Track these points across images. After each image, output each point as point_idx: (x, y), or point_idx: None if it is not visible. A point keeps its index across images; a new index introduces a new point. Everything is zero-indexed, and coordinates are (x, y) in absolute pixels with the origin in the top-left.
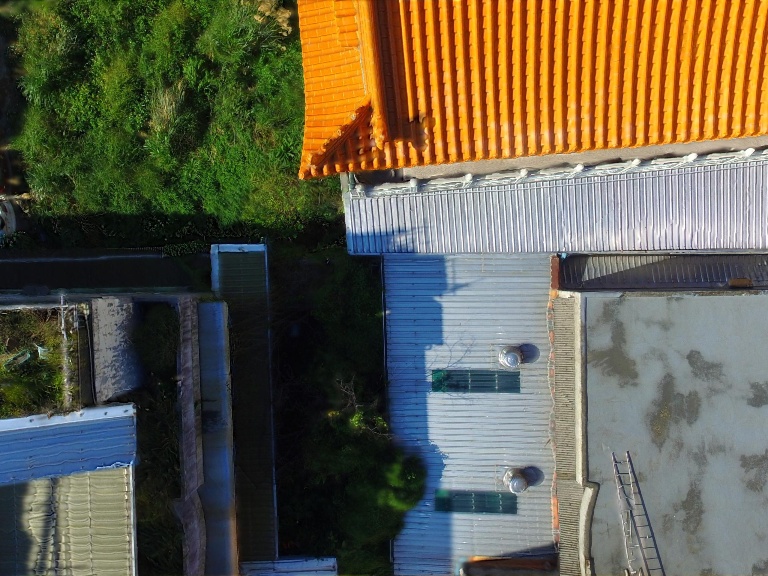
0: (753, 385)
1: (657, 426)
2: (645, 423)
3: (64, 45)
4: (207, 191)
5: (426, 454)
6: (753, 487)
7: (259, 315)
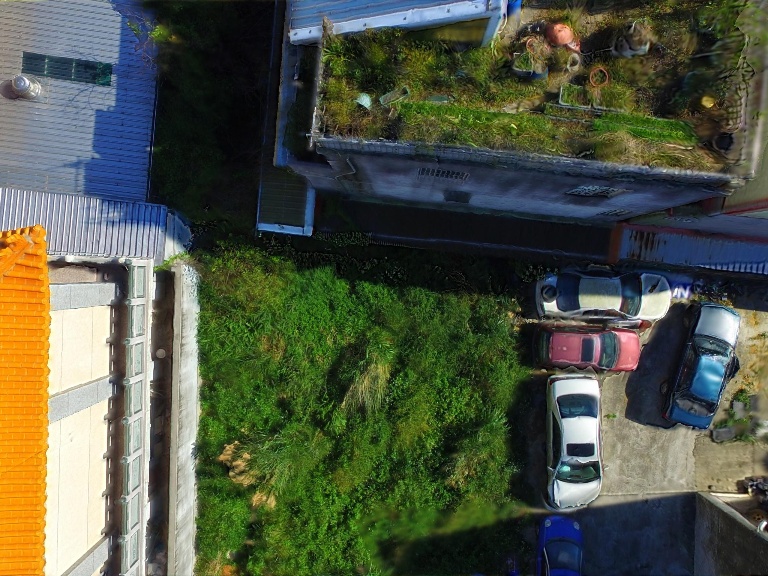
0: None
1: None
2: None
3: None
4: (342, 302)
5: (127, 3)
6: None
7: (271, 159)
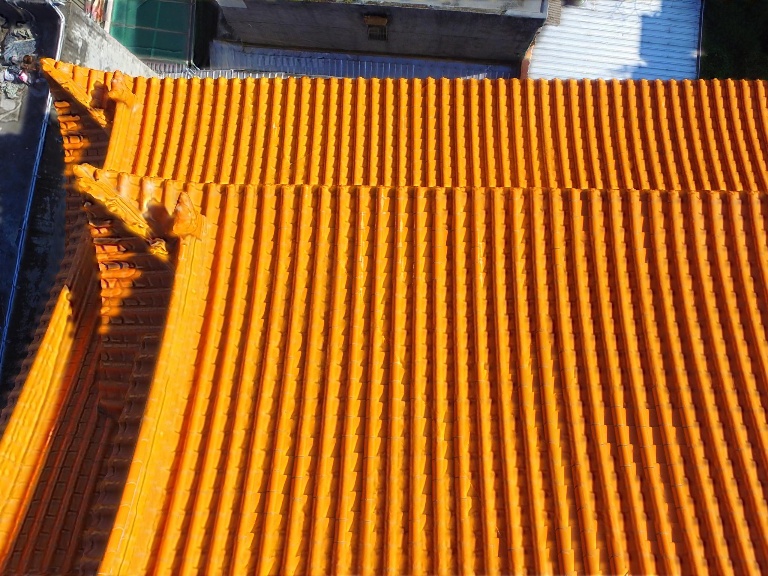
0: None
1: None
2: None
3: None
4: None
5: None
6: None
7: None
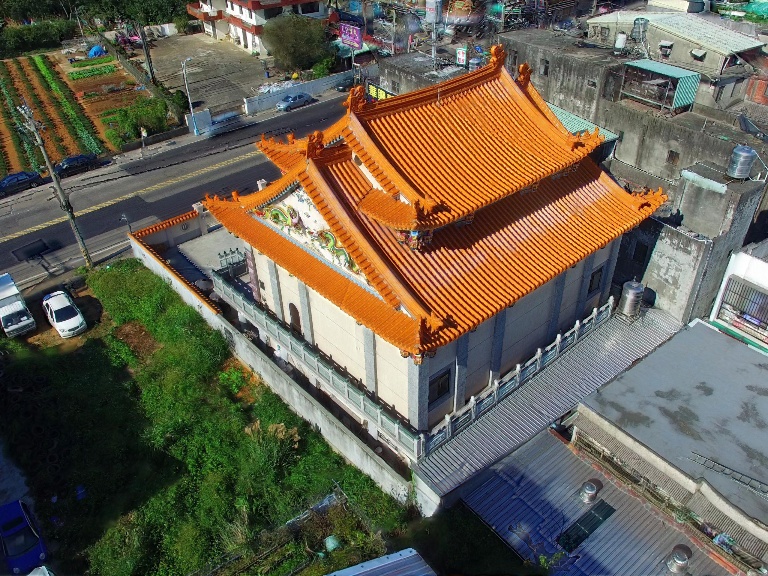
0: (697, 388)
1: (687, 432)
2: (680, 434)
3: (137, 540)
4: None
5: None
6: (762, 426)
7: None
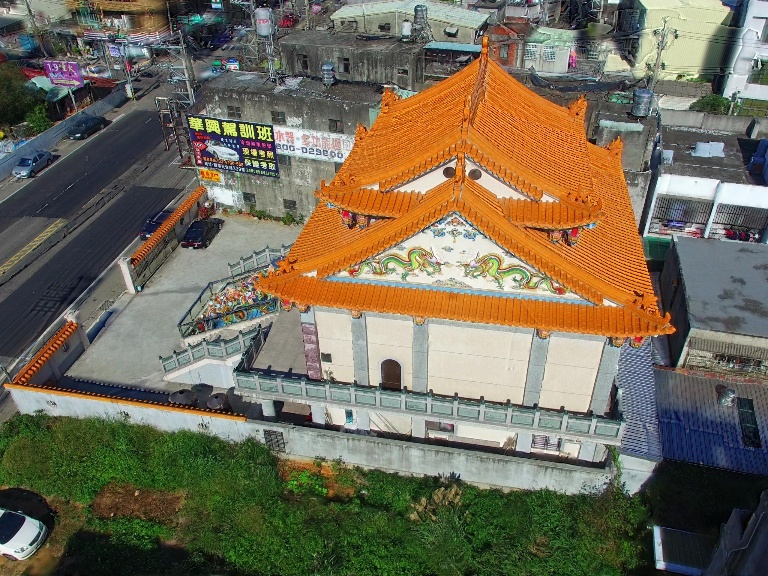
0: (734, 282)
1: (767, 315)
2: (767, 318)
3: None
4: None
5: None
6: None
7: None
